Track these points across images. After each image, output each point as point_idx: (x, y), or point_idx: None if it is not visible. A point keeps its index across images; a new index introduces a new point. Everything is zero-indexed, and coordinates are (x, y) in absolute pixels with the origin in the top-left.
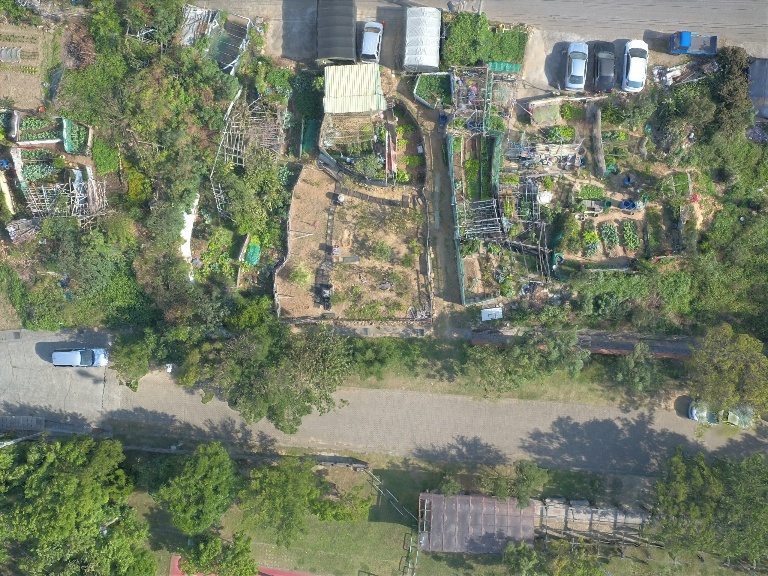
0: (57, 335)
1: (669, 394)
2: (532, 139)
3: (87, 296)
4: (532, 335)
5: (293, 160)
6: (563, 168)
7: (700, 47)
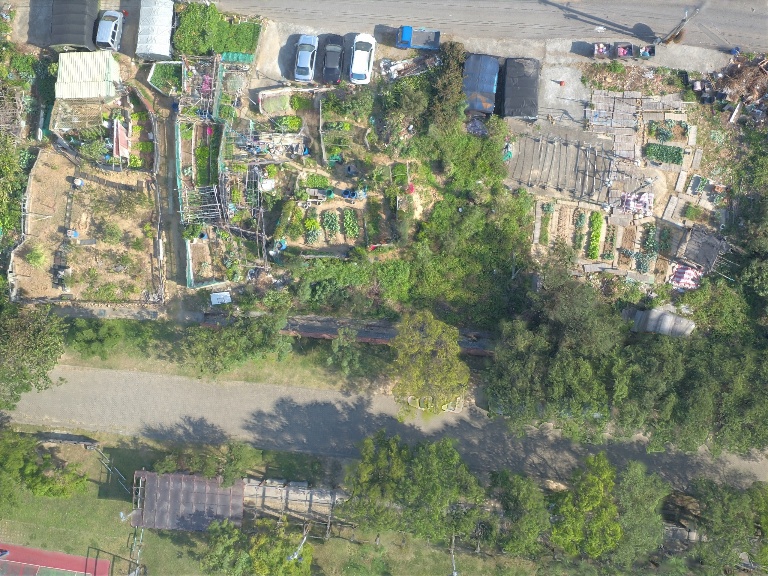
0: None
1: (388, 380)
2: (261, 128)
3: None
4: (245, 318)
5: (35, 144)
6: (290, 157)
7: (425, 42)
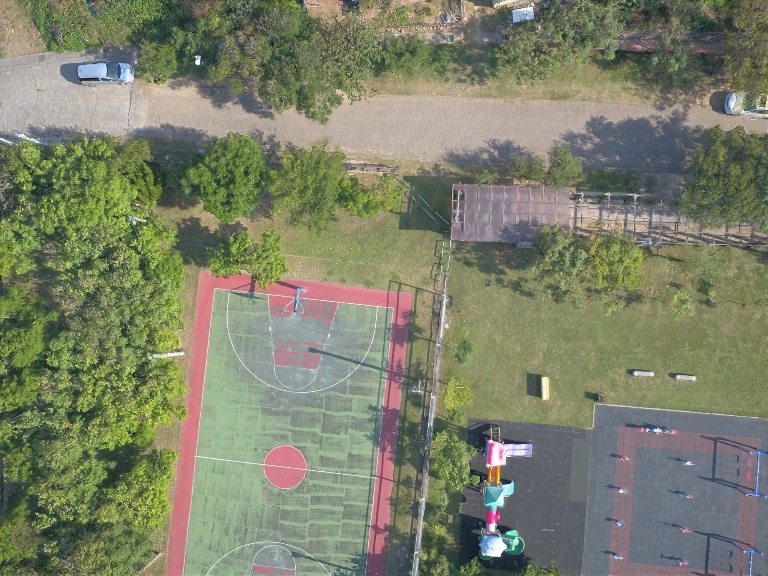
0: (82, 56)
1: (704, 90)
2: None
3: (113, 10)
4: None
5: None
6: None
7: None
